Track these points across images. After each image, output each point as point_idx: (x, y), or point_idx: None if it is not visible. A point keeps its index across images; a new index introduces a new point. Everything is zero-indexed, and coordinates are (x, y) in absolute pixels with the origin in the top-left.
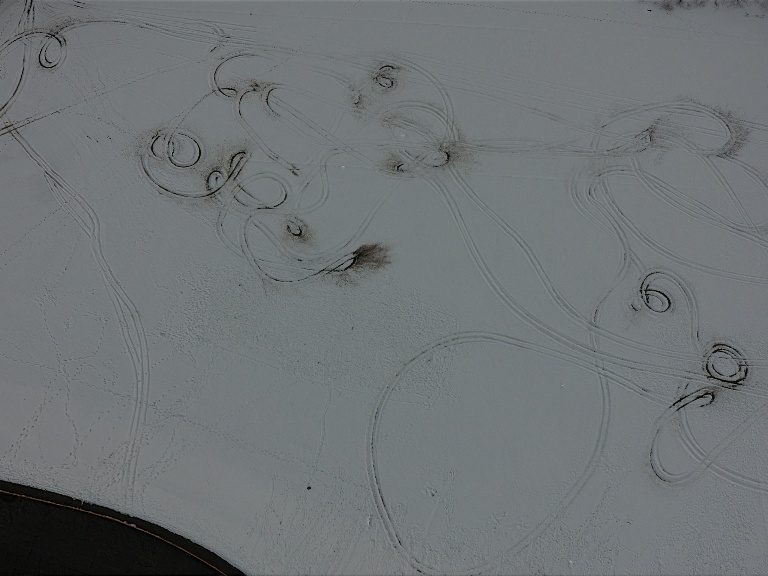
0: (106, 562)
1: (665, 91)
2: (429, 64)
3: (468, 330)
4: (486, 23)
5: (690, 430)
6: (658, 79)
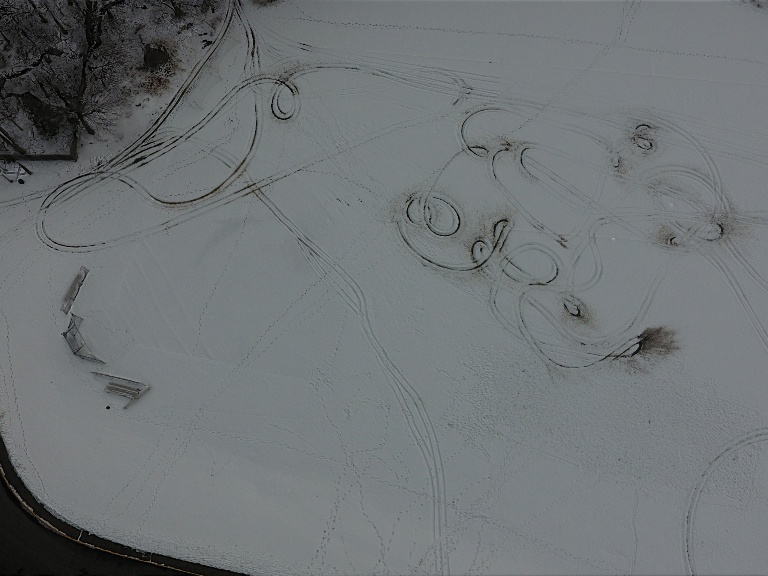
0: None
1: None
2: (687, 124)
3: None
4: (740, 78)
5: None
6: None
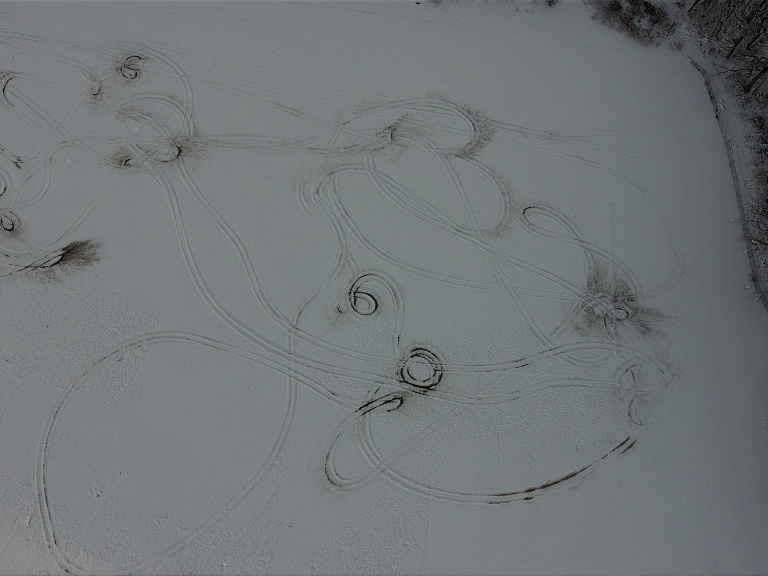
0: None
1: (416, 88)
2: (178, 55)
3: (165, 330)
4: (245, 13)
5: (371, 435)
6: (411, 75)
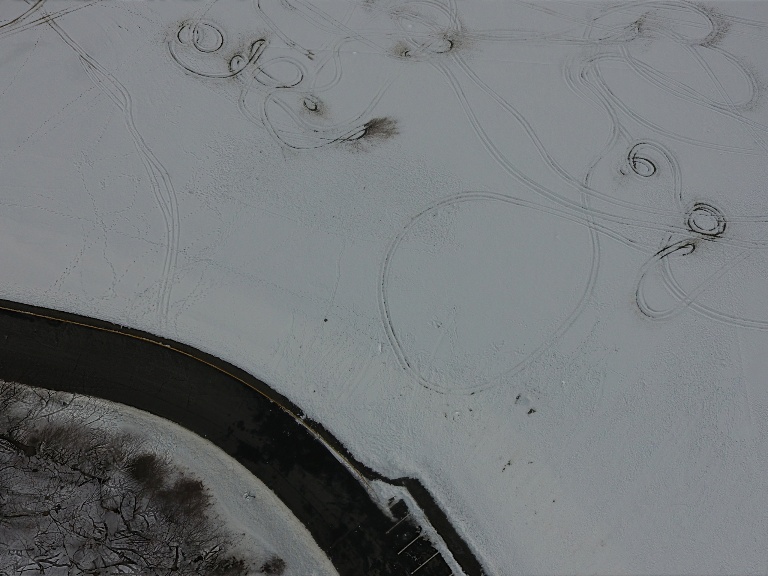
0: (144, 376)
1: None
2: None
3: (470, 190)
4: None
5: (672, 274)
6: None
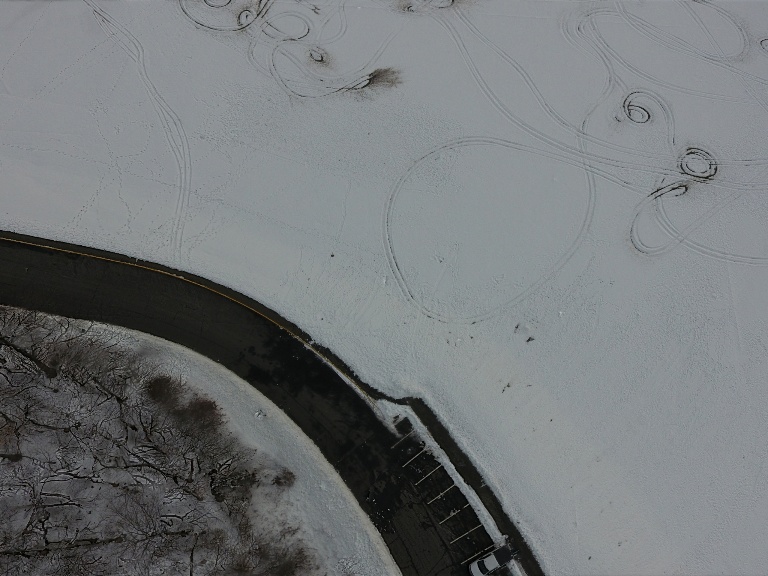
0: (159, 305)
1: None
2: None
3: (471, 135)
4: None
5: (666, 214)
6: None
